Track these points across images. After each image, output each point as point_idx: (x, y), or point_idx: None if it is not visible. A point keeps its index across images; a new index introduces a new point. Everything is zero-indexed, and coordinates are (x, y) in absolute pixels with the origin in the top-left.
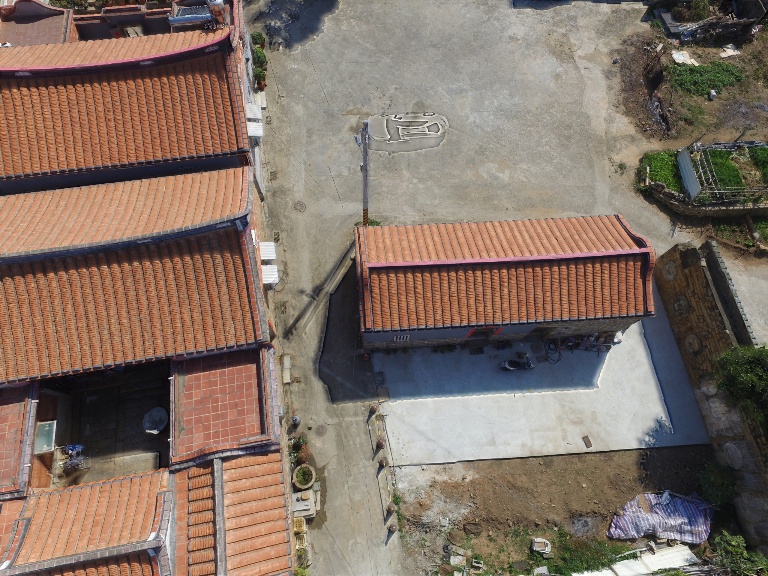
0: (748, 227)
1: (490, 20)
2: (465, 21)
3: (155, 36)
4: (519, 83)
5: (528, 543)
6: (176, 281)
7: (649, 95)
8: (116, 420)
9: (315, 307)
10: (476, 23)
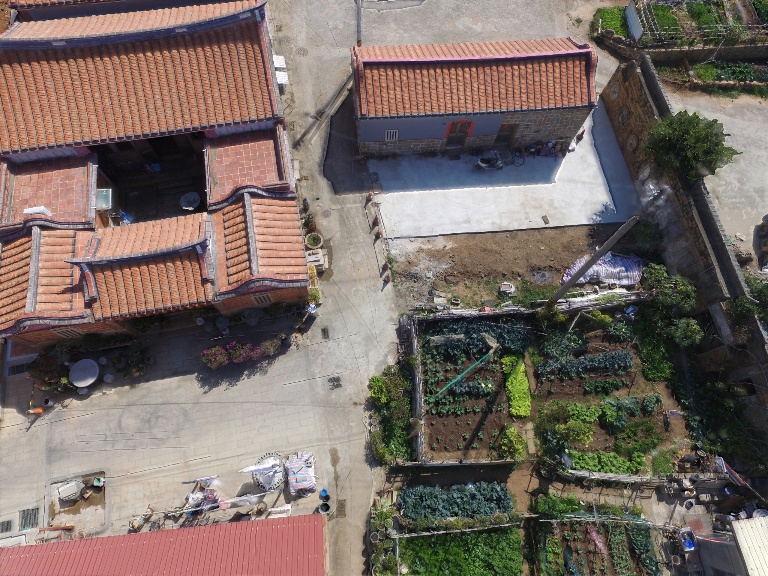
0: (685, 67)
1: None
2: None
3: None
4: None
5: (497, 288)
6: (207, 67)
7: None
8: (156, 209)
9: (319, 125)
10: None
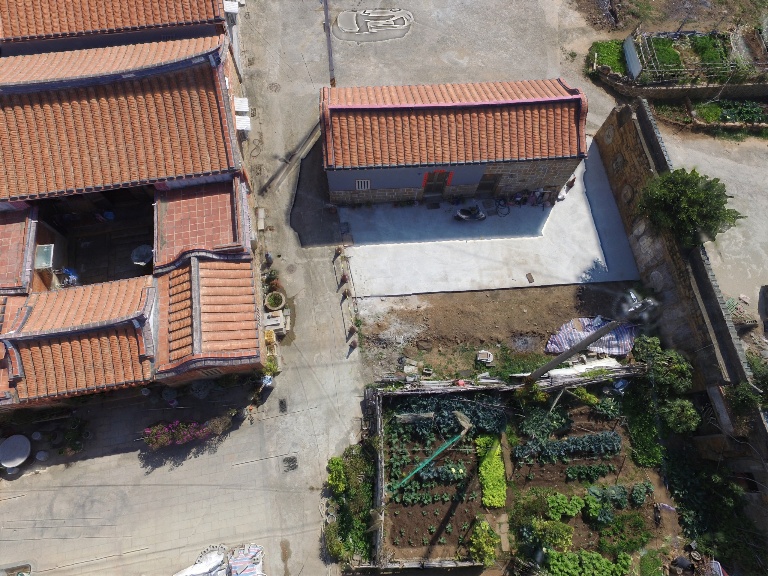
0: (687, 107)
1: None
2: None
3: None
4: None
5: (473, 356)
6: (157, 114)
7: None
8: (108, 261)
9: (287, 169)
10: None
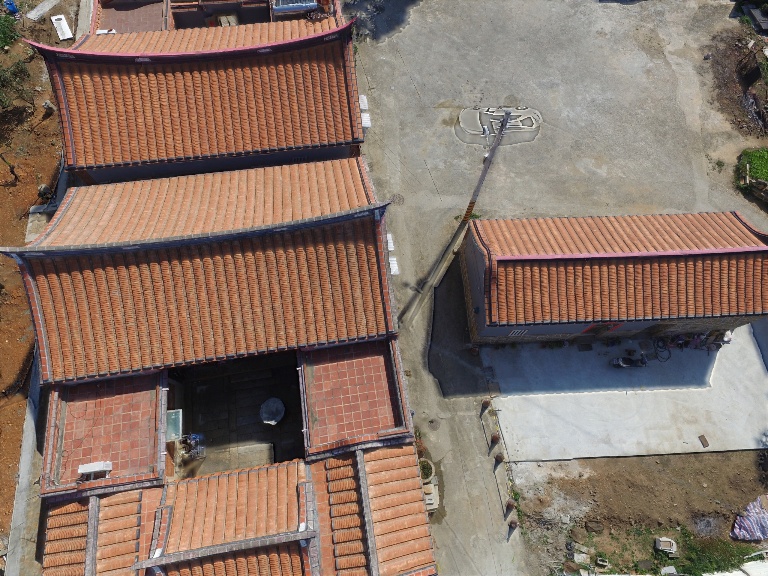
0: None
1: (576, 14)
2: (551, 15)
3: (261, 24)
4: (610, 78)
5: (651, 542)
6: (309, 270)
7: (743, 92)
8: (228, 410)
9: (420, 300)
10: (563, 17)
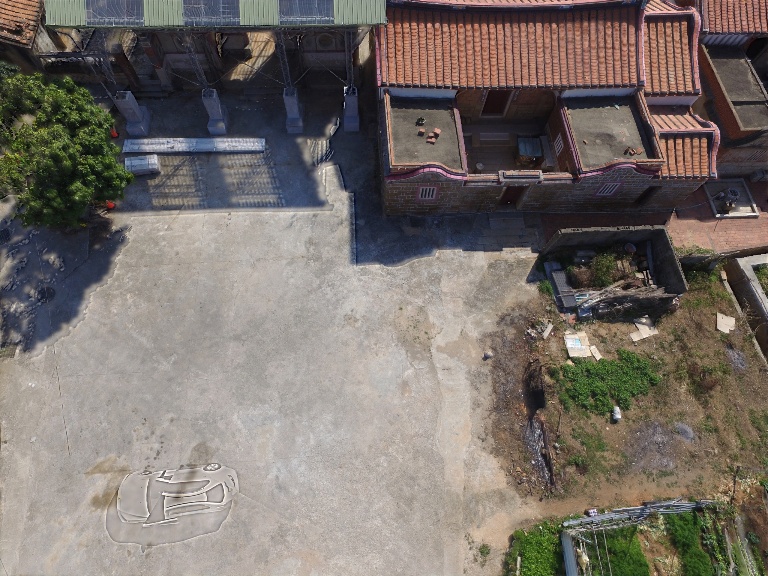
0: None
1: (321, 287)
2: (286, 291)
3: None
4: (349, 401)
5: None
6: None
7: (529, 417)
8: None
9: None
10: (301, 294)
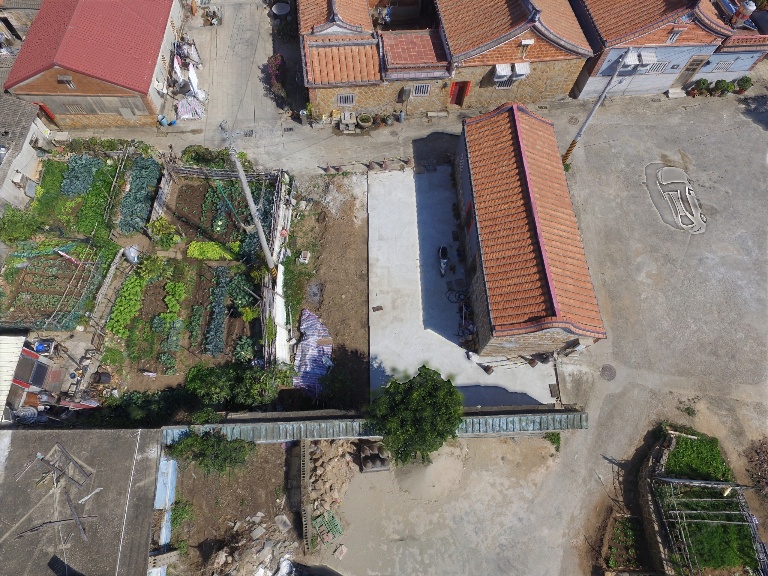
0: (637, 570)
1: None
2: None
3: None
4: None
5: None
6: (490, 6)
7: None
8: None
9: None
10: None
